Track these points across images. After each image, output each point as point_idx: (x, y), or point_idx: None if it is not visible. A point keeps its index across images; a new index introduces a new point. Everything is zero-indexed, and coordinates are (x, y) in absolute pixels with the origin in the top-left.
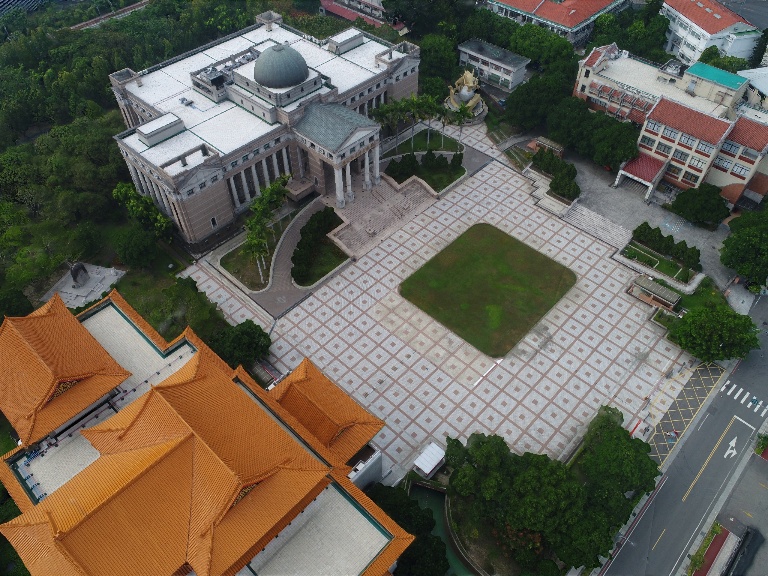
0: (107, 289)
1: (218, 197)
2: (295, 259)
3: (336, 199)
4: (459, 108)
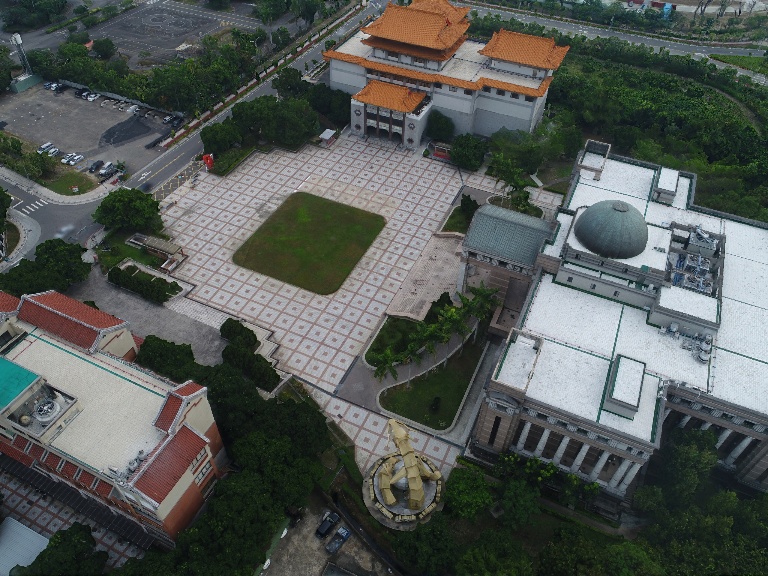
0: None
1: None
2: None
3: None
4: None
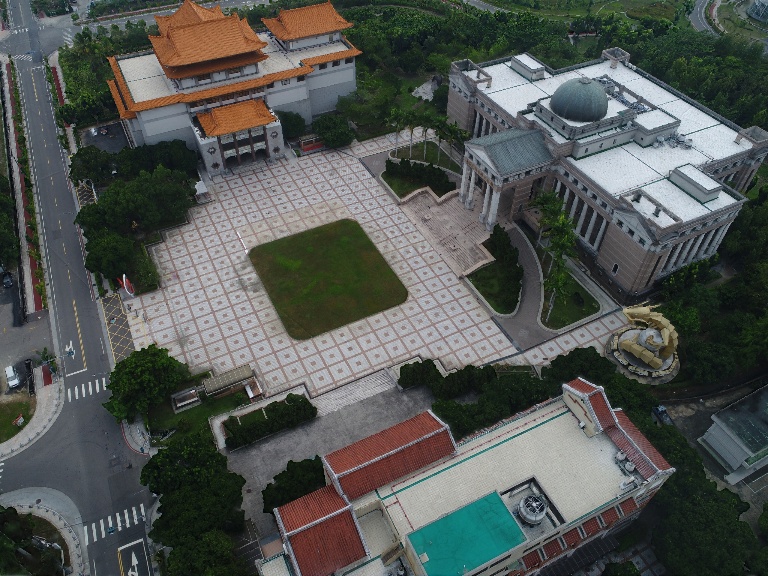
0: None
1: (463, 111)
2: None
3: None
4: (632, 338)
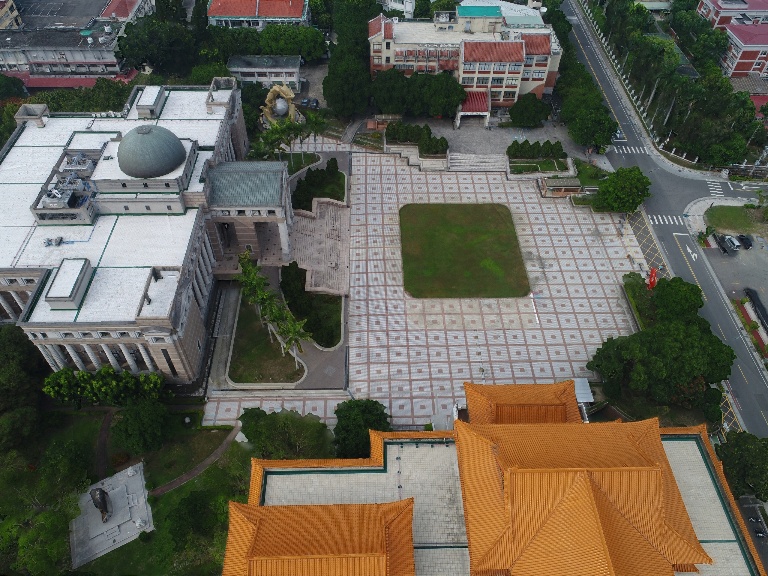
0: (144, 494)
1: (194, 316)
2: (309, 327)
3: (282, 254)
4: None
